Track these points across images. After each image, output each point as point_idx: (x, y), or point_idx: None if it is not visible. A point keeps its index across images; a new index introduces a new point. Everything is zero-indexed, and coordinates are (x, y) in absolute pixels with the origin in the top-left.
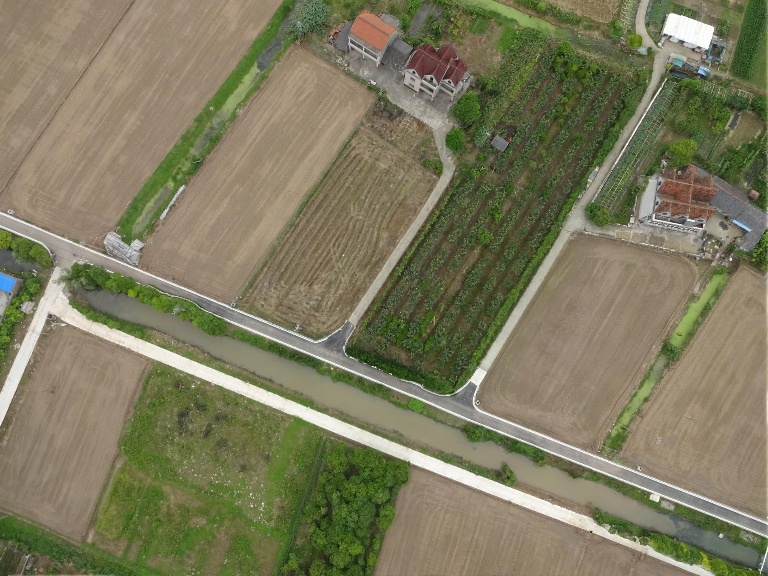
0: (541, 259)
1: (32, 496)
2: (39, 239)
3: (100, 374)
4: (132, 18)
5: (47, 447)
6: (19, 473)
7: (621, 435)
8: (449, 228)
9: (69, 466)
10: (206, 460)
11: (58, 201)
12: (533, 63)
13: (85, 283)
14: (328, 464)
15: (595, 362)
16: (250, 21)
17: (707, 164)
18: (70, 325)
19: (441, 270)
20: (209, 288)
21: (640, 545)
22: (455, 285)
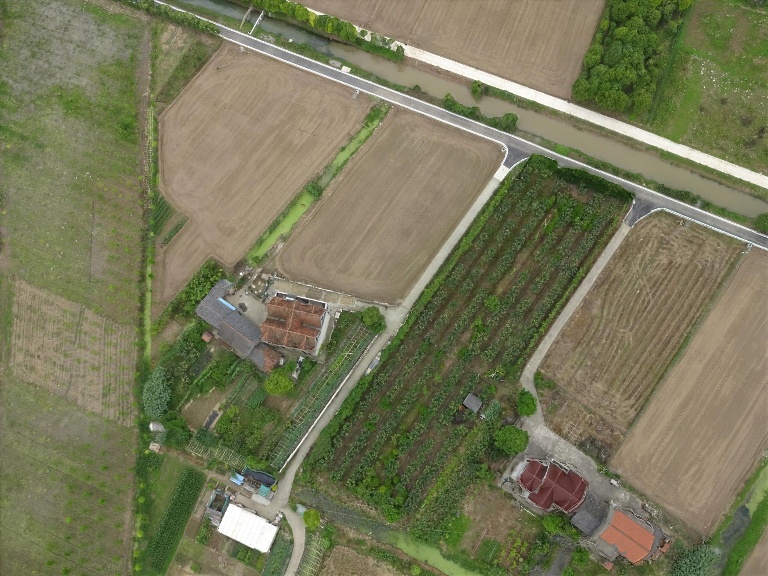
0: None
1: None
2: None
3: None
4: None
5: None
6: None
7: (370, 120)
8: (528, 315)
9: None
10: (760, 109)
11: None
12: (429, 499)
13: None
14: None
15: (388, 183)
16: (764, 571)
17: (252, 370)
18: None
19: (537, 273)
20: None
21: None
22: (523, 258)
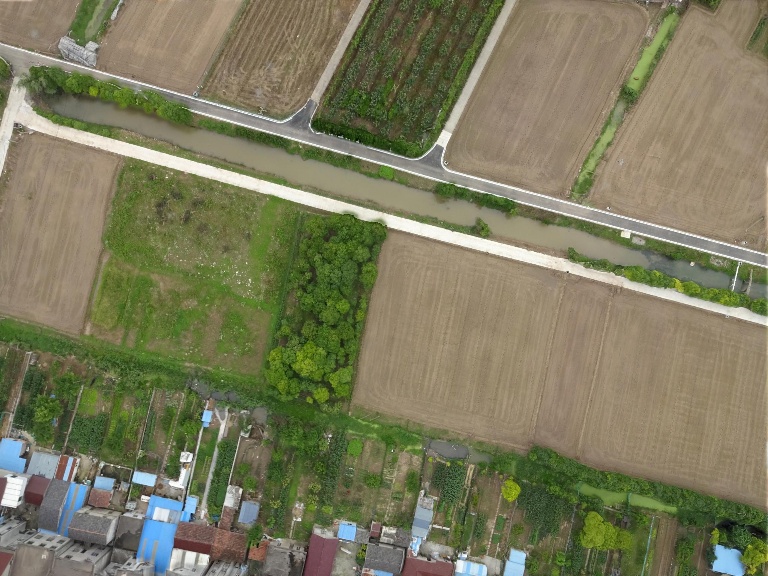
0: (493, 19)
1: (25, 298)
2: None
3: (74, 176)
4: None
5: (33, 251)
6: (9, 278)
7: (588, 179)
8: None
9: (57, 266)
10: (189, 245)
11: (7, 12)
12: None
13: (45, 85)
14: (307, 229)
15: (556, 113)
16: None
17: None
18: (37, 132)
19: (396, 40)
20: (169, 82)
21: (616, 279)
22: (412, 53)
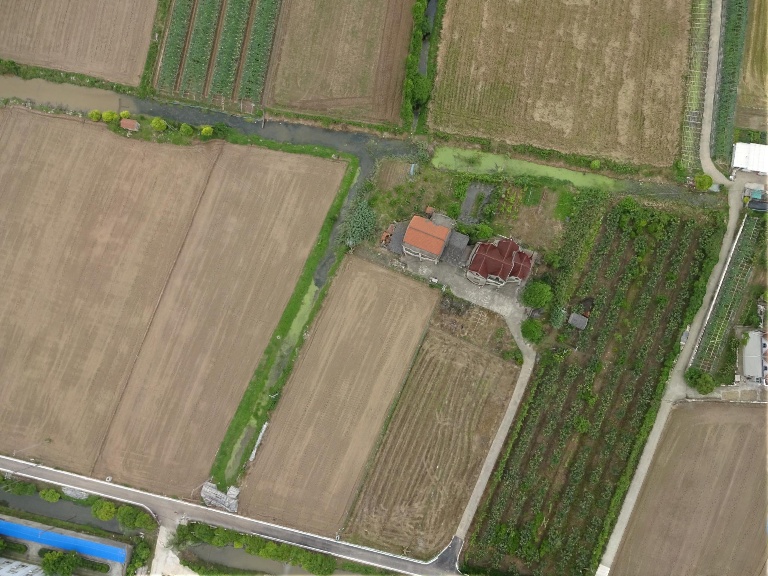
0: (645, 437)
1: None
2: (140, 501)
3: None
4: (185, 259)
5: None
6: None
7: None
8: (541, 420)
9: None
10: None
11: (150, 459)
12: (597, 226)
13: (192, 543)
14: None
15: (725, 539)
16: (299, 239)
17: None
18: None
19: (541, 466)
20: (310, 523)
21: None
22: (559, 479)
